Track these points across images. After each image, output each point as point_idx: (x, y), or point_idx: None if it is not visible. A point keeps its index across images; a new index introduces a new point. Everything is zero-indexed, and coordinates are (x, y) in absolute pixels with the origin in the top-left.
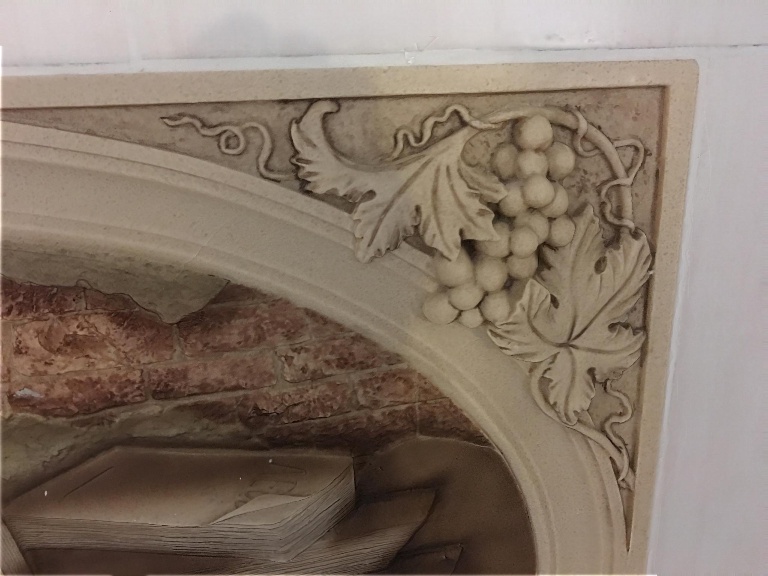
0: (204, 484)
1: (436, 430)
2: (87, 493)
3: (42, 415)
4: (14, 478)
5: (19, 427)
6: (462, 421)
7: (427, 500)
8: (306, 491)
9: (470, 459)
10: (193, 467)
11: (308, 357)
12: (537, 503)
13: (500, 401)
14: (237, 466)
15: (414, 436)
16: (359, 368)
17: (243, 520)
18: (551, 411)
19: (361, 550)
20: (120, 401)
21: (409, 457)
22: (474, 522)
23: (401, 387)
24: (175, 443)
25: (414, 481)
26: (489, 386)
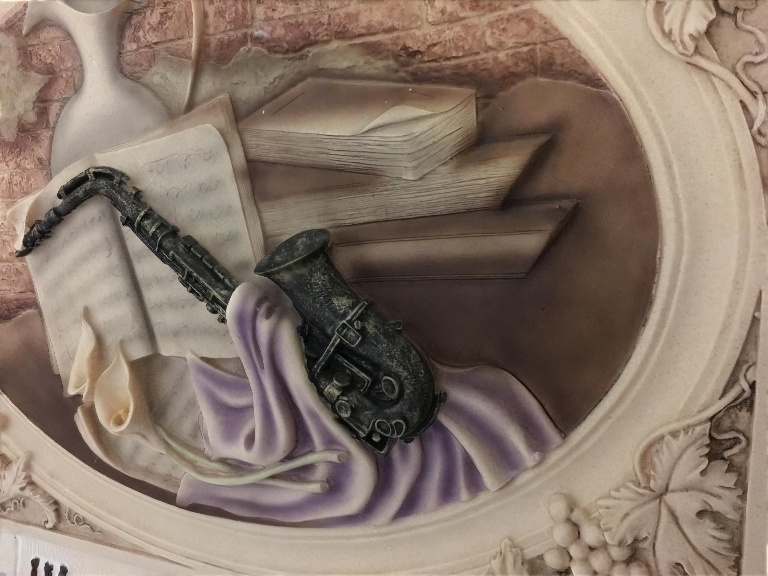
0: (360, 105)
1: (555, 73)
2: (286, 111)
3: (267, 50)
4: (248, 100)
5: (253, 58)
6: (580, 63)
7: (541, 140)
8: (432, 110)
9: (587, 103)
10: (355, 93)
11: (447, 0)
12: (659, 159)
13: (620, 44)
14: (385, 93)
15: (534, 78)
16: (488, 10)
17: (383, 133)
18: (669, 44)
19: (478, 181)
20: (314, 40)
21: (528, 98)
22: (591, 176)
23: (523, 28)
24: (346, 76)
25: (533, 125)
26: (609, 27)
